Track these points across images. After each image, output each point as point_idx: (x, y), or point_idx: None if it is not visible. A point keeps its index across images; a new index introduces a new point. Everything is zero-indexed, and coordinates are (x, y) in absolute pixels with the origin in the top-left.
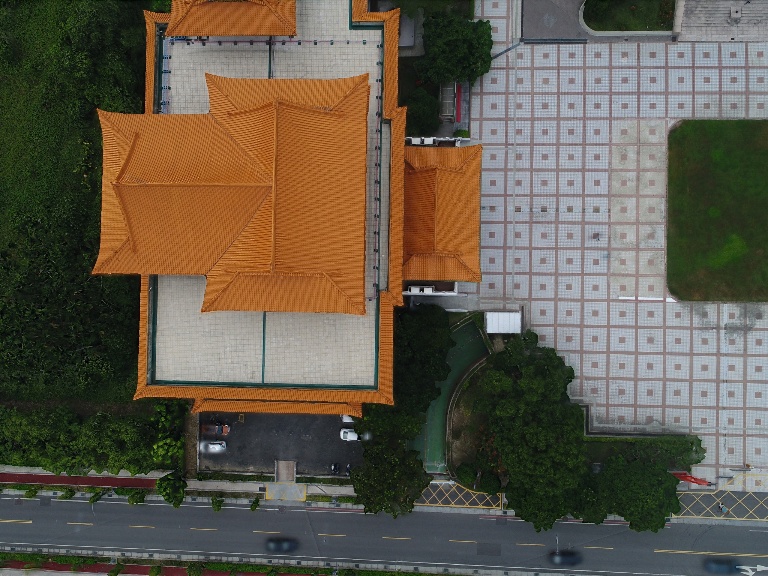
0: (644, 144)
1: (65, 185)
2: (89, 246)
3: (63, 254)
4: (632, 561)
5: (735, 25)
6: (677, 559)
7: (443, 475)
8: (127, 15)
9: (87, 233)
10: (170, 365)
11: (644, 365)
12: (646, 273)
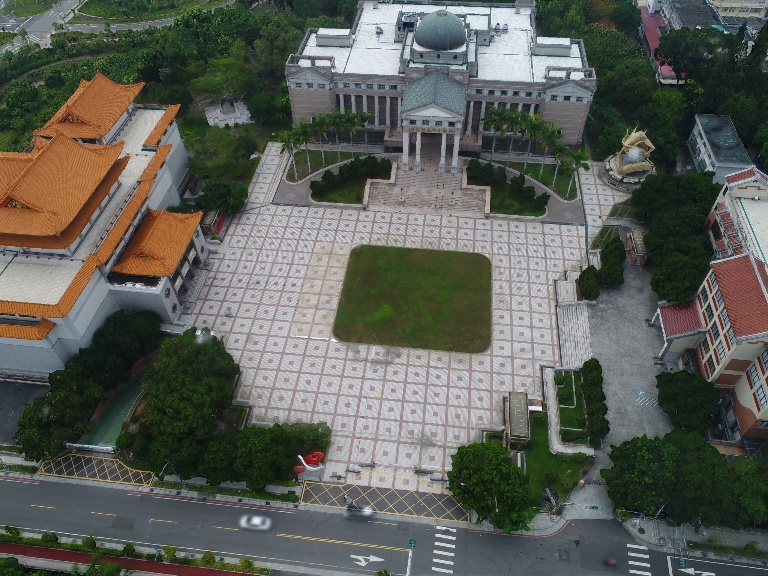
0: (334, 254)
1: None
2: None
3: None
4: (253, 543)
5: (402, 206)
6: (296, 544)
7: (111, 454)
8: None
9: None
10: None
11: (304, 381)
12: (319, 323)
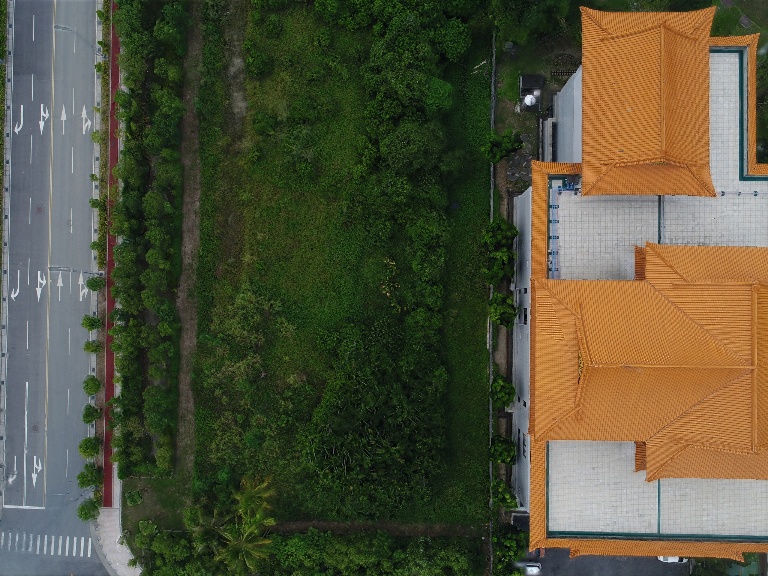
0: None
1: (367, 303)
2: (421, 375)
3: (374, 376)
4: None
5: None
6: None
7: None
8: (446, 140)
9: (404, 357)
10: (564, 516)
11: None
12: None
